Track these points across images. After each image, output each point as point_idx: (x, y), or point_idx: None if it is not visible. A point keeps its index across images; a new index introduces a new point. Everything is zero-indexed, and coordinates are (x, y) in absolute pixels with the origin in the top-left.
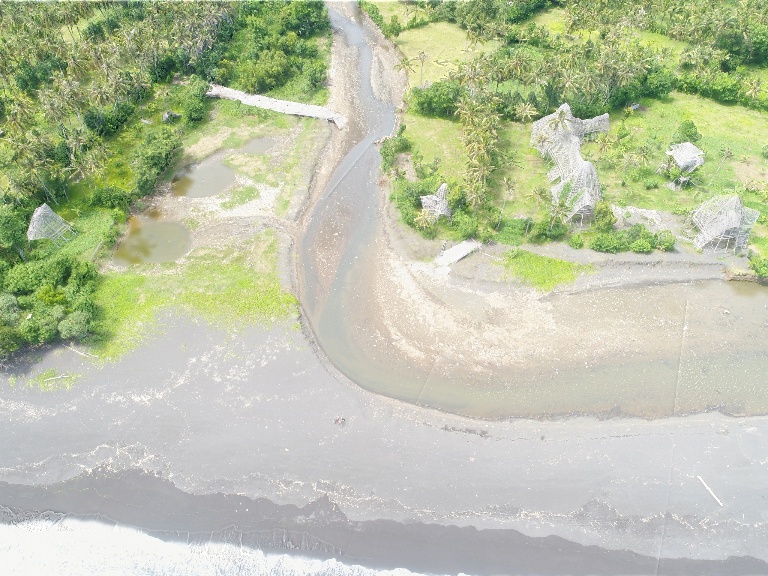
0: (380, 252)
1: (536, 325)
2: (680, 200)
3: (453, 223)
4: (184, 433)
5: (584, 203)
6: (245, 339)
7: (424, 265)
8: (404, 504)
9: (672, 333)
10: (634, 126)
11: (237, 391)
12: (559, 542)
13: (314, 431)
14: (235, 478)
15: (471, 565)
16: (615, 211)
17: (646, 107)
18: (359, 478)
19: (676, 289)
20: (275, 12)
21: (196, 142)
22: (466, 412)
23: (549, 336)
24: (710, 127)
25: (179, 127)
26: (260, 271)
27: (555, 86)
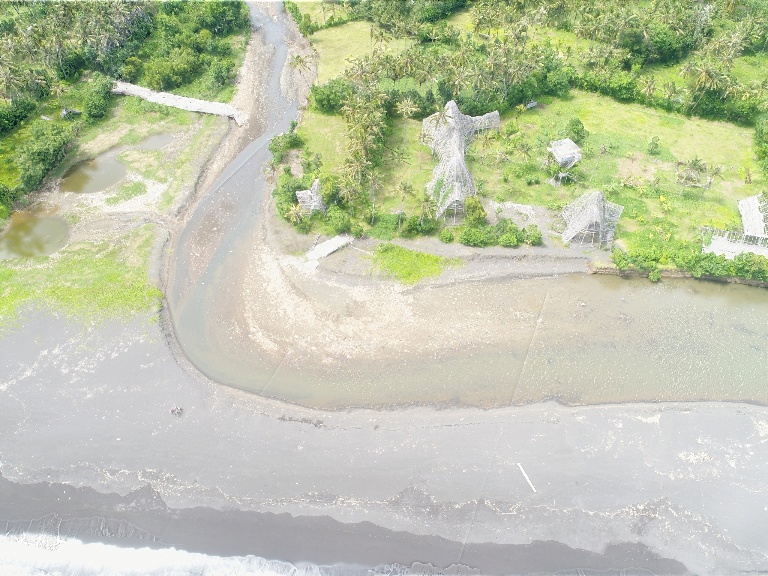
0: (255, 247)
1: (393, 318)
2: (558, 196)
3: (328, 218)
4: (21, 424)
5: (454, 198)
6: (101, 332)
7: (295, 259)
8: (224, 492)
9: (526, 325)
10: (529, 123)
11: (82, 382)
12: (370, 528)
13: (150, 421)
14: (62, 467)
15: (281, 551)
16: (492, 206)
17: (545, 105)
18: (185, 467)
19: (539, 282)
20: (197, 10)
21: (93, 138)
22: (307, 402)
23: (404, 328)
24: (603, 124)
25: (76, 123)
26: (131, 265)
27: (446, 83)
